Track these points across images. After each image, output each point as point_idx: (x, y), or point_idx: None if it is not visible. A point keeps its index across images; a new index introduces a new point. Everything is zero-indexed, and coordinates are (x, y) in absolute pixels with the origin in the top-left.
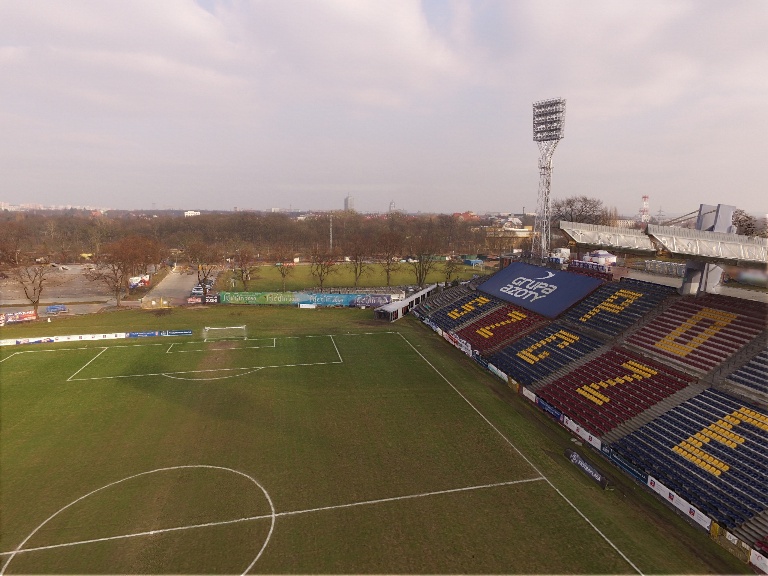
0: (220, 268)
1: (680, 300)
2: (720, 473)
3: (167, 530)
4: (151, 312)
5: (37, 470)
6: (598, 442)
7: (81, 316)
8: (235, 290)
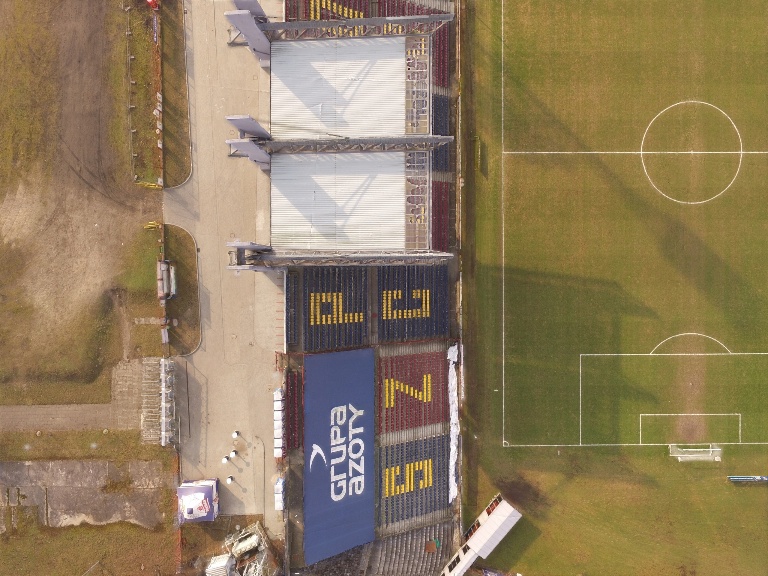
0: None
1: None
2: None
3: (686, 152)
4: None
5: (761, 215)
6: None
7: None
8: None
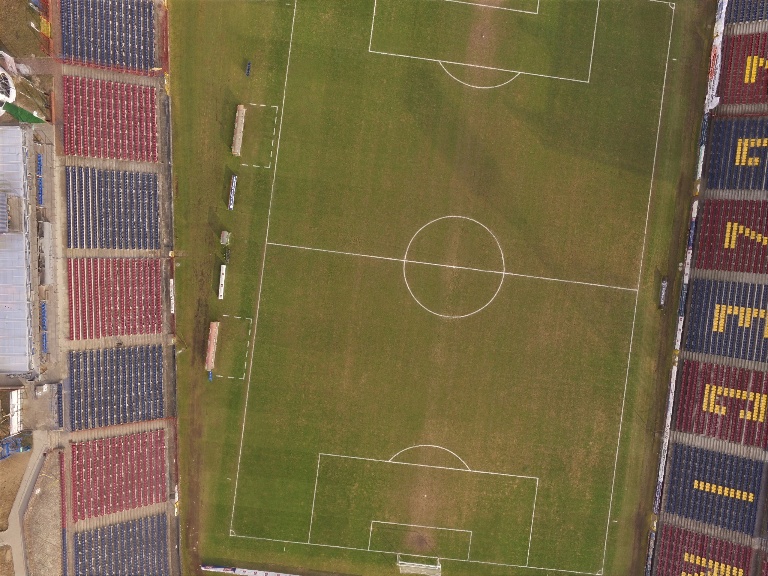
0: None
1: None
2: (716, 331)
3: (460, 268)
4: None
5: (392, 195)
6: (686, 281)
7: None
8: None
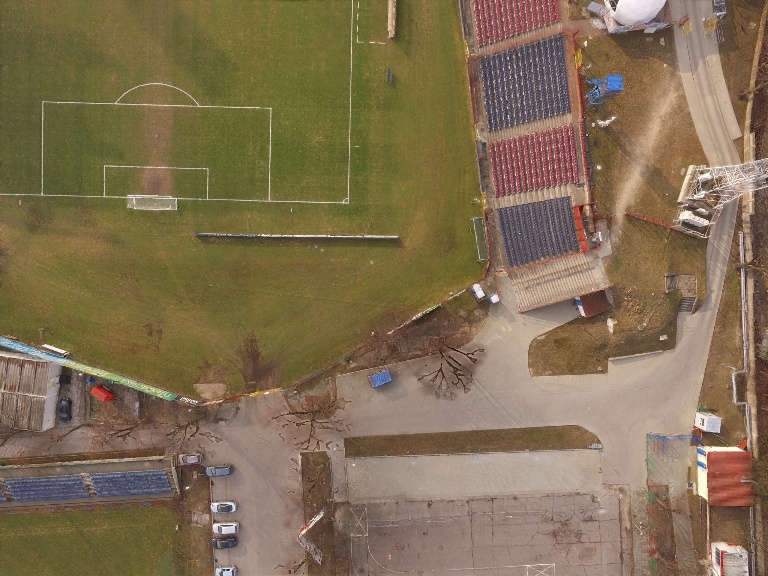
0: None
1: None
2: None
3: None
4: (267, 365)
5: None
6: None
7: (346, 353)
8: (177, 569)
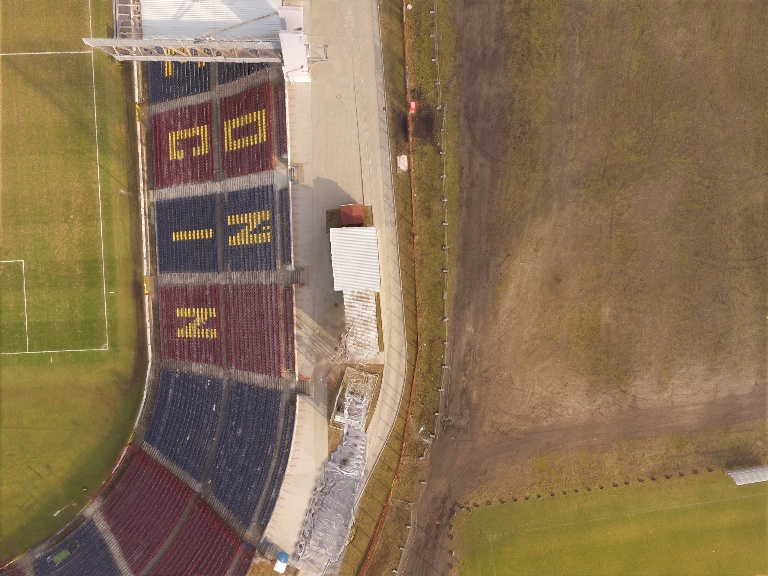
0: None
1: None
2: (167, 76)
3: None
4: None
5: None
6: None
7: None
8: None
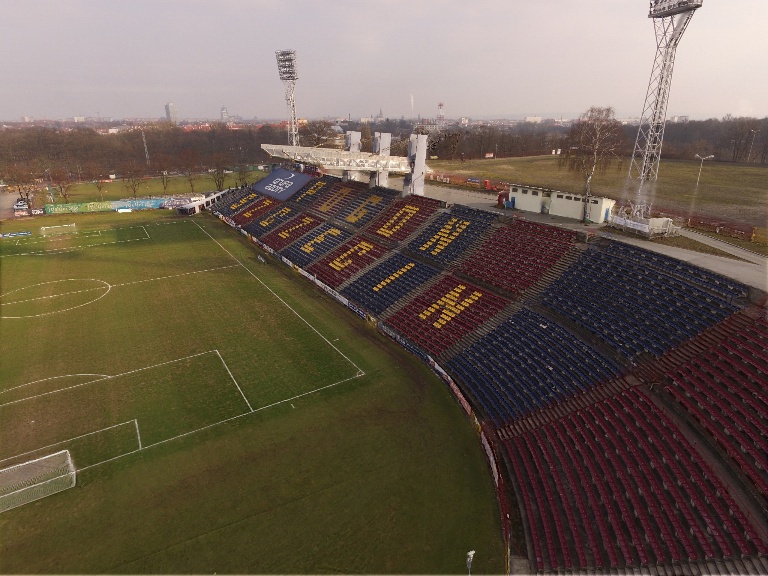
0: (32, 188)
1: (338, 185)
2: (310, 252)
3: (58, 295)
4: None
5: None
6: (272, 250)
7: None
8: None
